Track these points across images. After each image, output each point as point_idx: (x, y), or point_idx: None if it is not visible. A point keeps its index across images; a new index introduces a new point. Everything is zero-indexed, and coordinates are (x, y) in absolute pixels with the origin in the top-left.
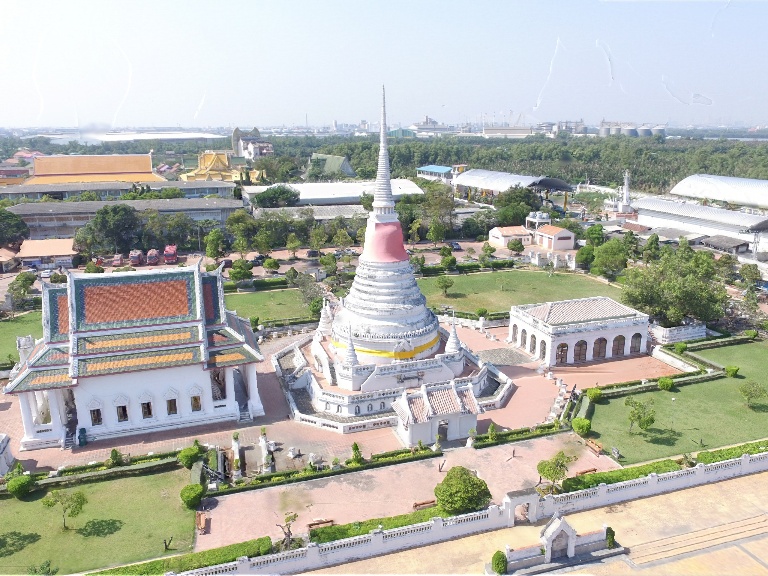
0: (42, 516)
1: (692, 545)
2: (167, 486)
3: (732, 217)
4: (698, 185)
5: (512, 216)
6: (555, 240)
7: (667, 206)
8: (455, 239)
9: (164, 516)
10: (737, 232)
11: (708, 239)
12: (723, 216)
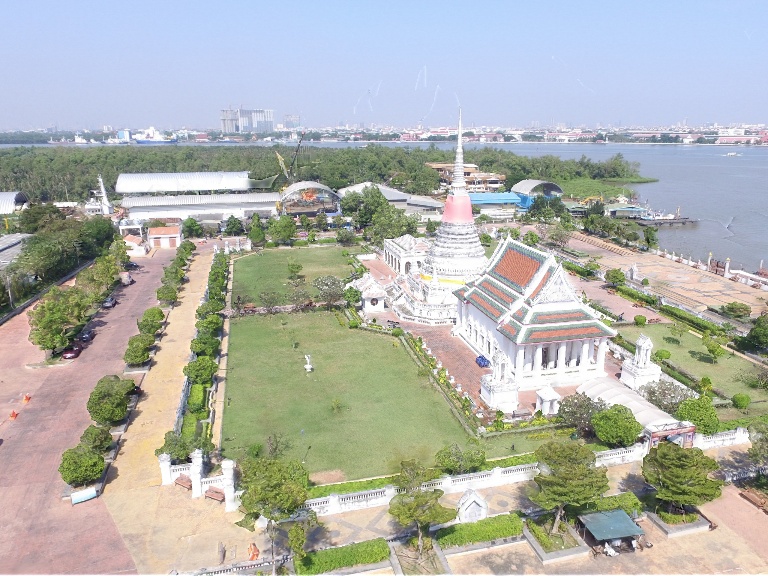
0: (675, 353)
1: (610, 269)
2: (628, 332)
3: (233, 198)
4: (142, 182)
5: (108, 228)
6: (180, 237)
7: (164, 200)
8: (84, 264)
9: (653, 330)
10: (239, 208)
11: (248, 214)
12: (225, 198)
